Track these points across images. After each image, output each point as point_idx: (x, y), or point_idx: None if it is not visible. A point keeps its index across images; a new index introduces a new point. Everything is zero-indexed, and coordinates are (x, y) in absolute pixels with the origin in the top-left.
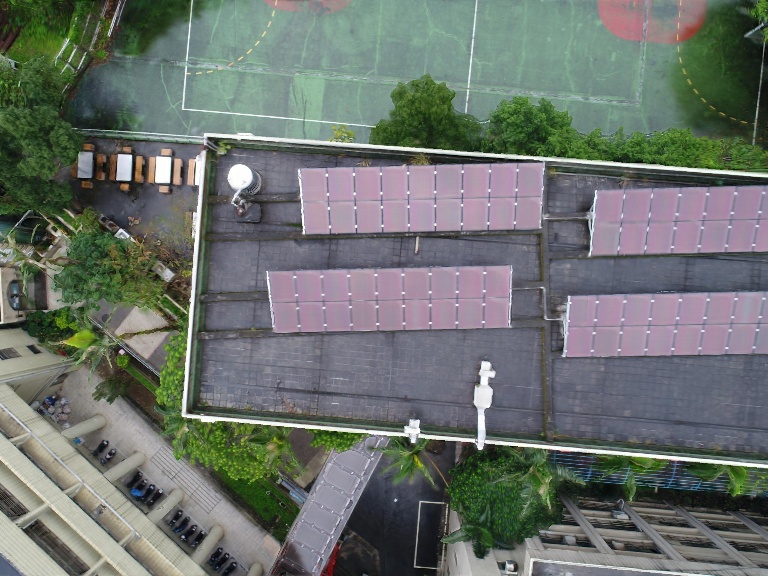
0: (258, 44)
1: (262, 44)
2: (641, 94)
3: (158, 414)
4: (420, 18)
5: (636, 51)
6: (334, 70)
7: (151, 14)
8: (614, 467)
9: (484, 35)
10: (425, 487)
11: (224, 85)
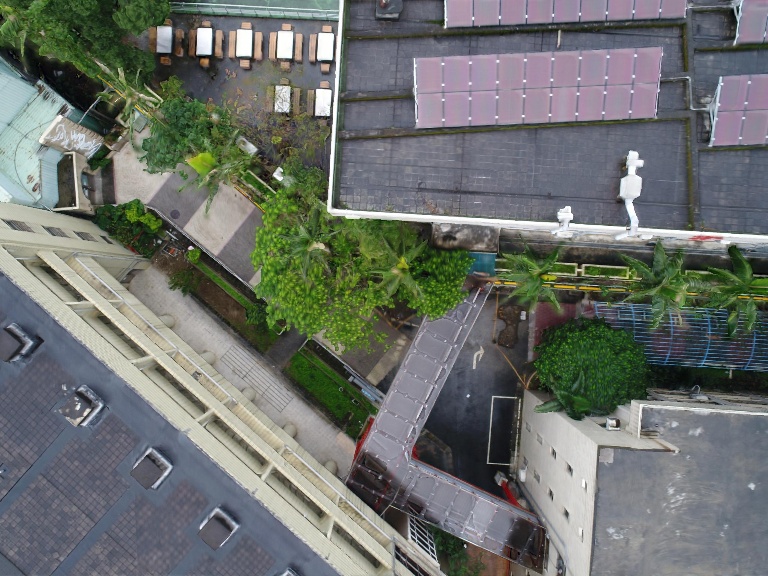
0: None
1: None
2: None
3: (227, 313)
4: None
5: None
6: None
7: None
8: (735, 292)
9: None
10: (498, 382)
11: None
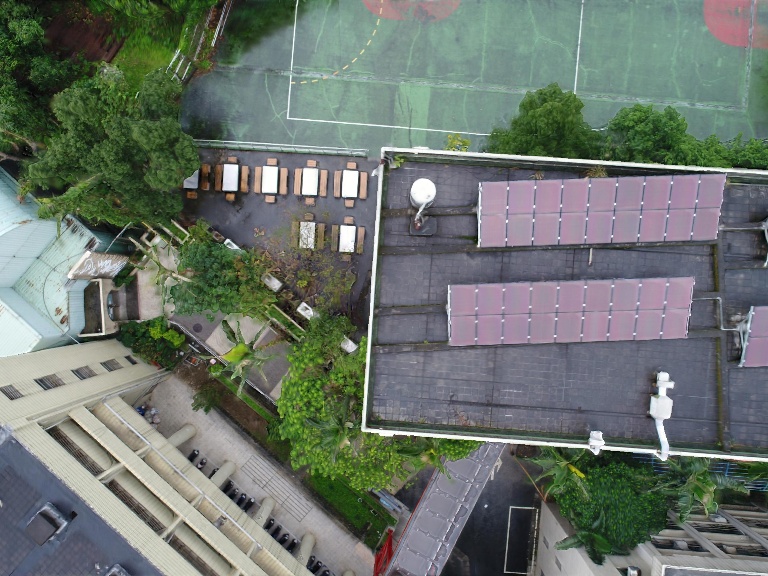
0: (363, 53)
1: (367, 53)
2: (747, 99)
3: (248, 423)
4: (526, 25)
5: (742, 57)
6: (440, 78)
7: (255, 23)
8: (761, 474)
9: (590, 42)
10: (515, 492)
11: (329, 94)
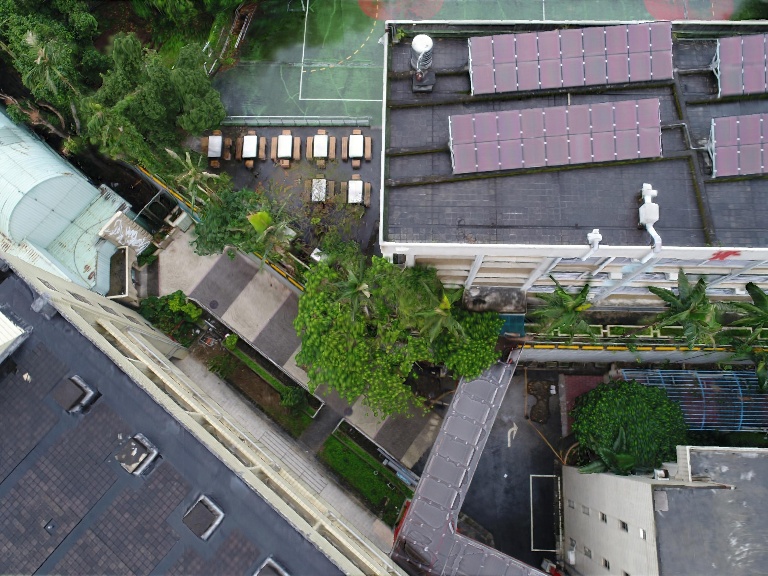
0: (363, 46)
1: (367, 46)
2: None
3: (261, 399)
4: None
5: None
6: None
7: (271, 30)
8: (760, 321)
9: None
10: (534, 459)
11: (335, 79)
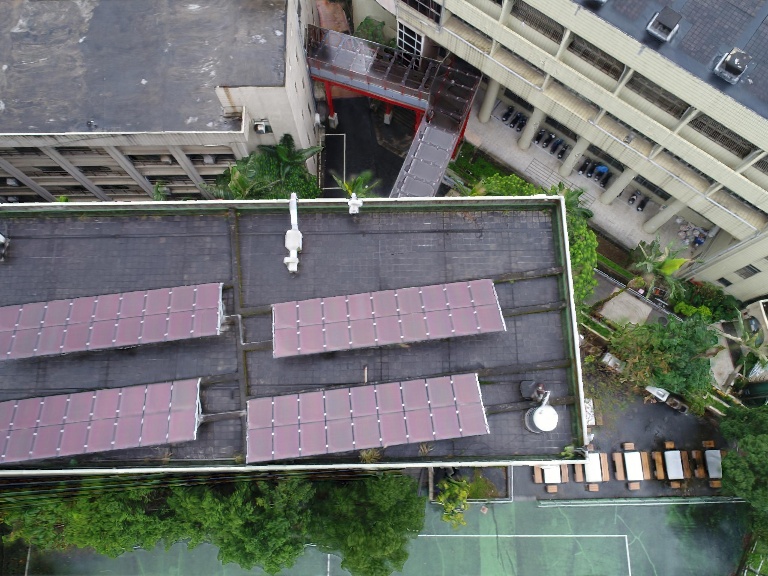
0: None
1: None
2: None
3: None
4: None
5: None
6: None
7: None
8: None
9: None
10: None
11: (587, 567)
